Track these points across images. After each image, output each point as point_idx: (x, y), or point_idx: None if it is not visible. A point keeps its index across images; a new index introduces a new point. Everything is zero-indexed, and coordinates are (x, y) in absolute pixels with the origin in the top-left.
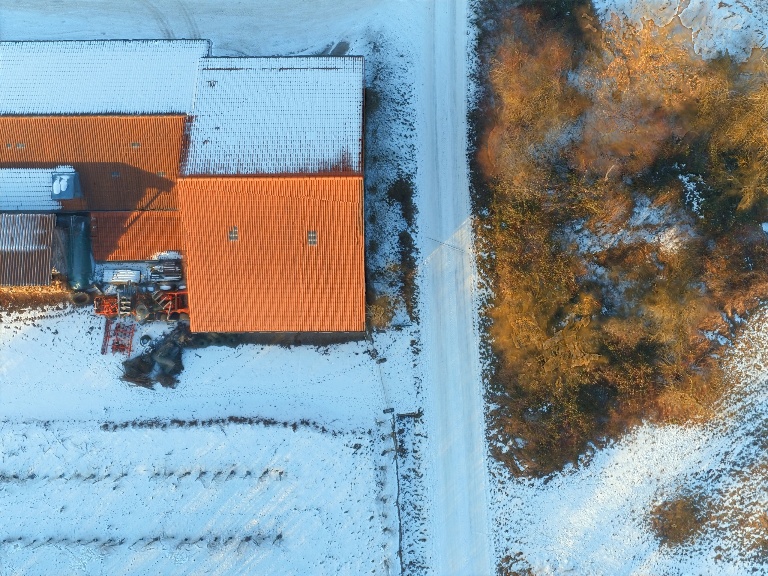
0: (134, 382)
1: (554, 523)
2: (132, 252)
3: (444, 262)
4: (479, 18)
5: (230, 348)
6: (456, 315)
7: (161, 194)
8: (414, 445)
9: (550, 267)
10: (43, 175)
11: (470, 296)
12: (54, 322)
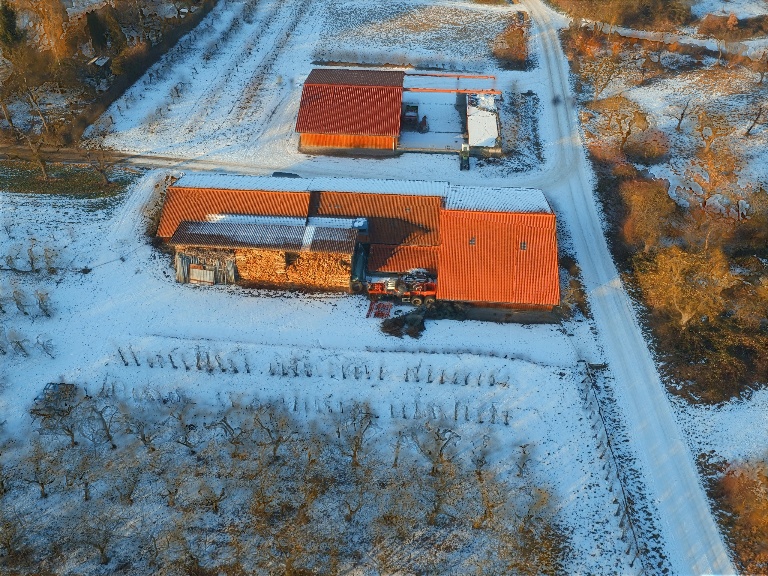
0: (391, 330)
1: (735, 432)
2: (394, 267)
3: (605, 293)
4: (601, 200)
5: (459, 321)
6: (620, 318)
7: (418, 236)
8: (605, 384)
9: (682, 289)
10: (346, 222)
11: (627, 309)
12: (335, 300)
